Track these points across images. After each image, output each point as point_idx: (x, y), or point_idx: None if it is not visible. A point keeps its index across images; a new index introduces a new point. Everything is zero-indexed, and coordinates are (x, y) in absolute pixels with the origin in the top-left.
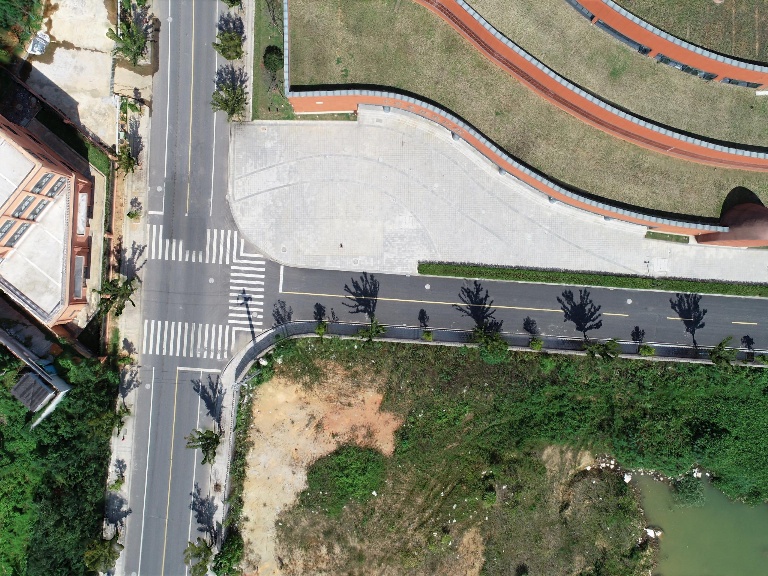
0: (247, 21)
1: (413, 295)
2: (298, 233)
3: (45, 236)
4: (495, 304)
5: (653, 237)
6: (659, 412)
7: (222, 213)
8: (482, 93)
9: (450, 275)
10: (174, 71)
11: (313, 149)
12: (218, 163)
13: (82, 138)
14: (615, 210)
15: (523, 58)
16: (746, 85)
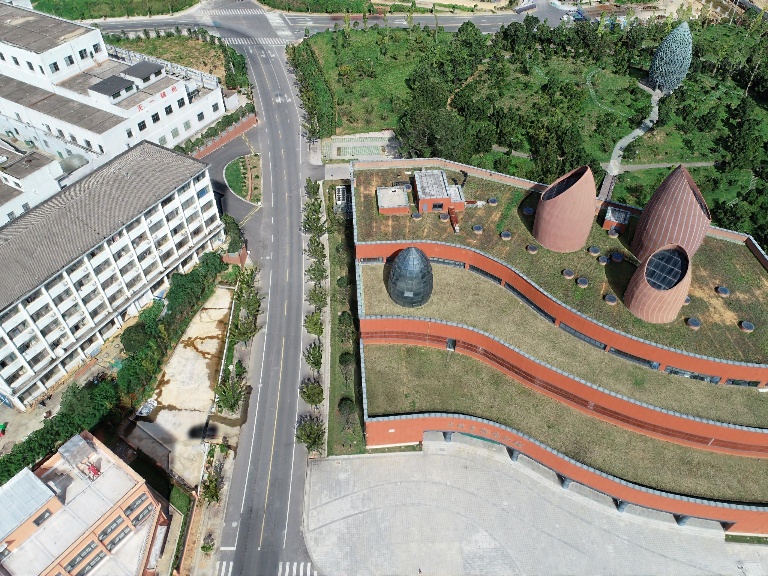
0: (324, 383)
1: None
2: (374, 560)
3: (116, 569)
4: None
5: (734, 540)
6: None
7: (296, 545)
8: (531, 412)
9: None
10: (260, 422)
11: (384, 477)
12: (294, 496)
13: (169, 479)
14: (686, 499)
15: (561, 375)
16: (747, 385)
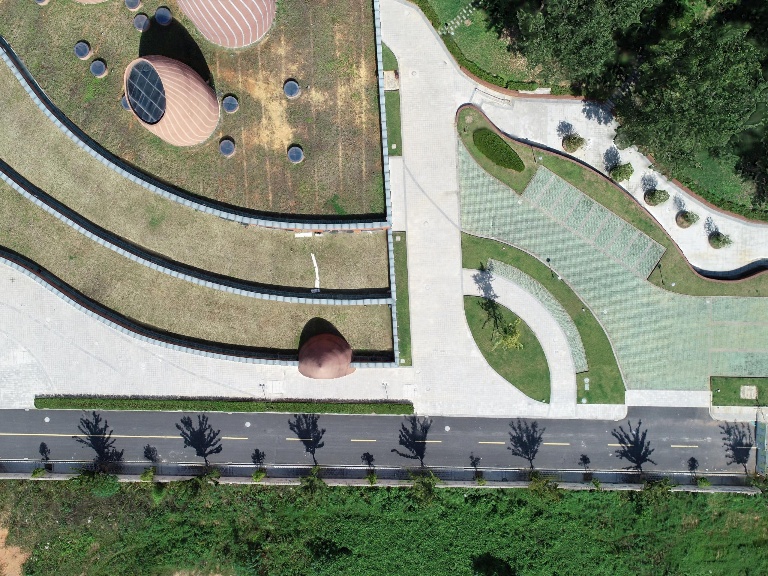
0: None
1: (33, 429)
2: None
3: None
4: (115, 434)
5: None
6: (282, 533)
7: None
8: (55, 238)
9: (66, 408)
10: None
11: None
12: None
13: None
14: (185, 350)
15: (54, 215)
16: None
